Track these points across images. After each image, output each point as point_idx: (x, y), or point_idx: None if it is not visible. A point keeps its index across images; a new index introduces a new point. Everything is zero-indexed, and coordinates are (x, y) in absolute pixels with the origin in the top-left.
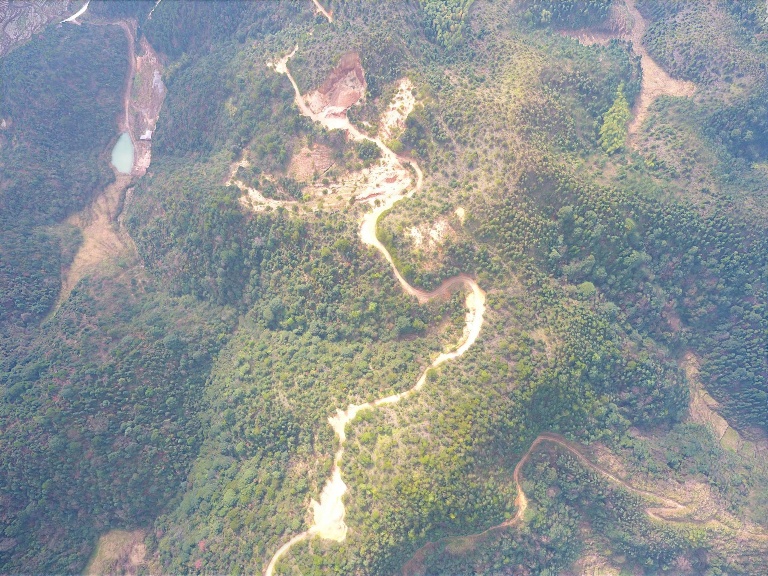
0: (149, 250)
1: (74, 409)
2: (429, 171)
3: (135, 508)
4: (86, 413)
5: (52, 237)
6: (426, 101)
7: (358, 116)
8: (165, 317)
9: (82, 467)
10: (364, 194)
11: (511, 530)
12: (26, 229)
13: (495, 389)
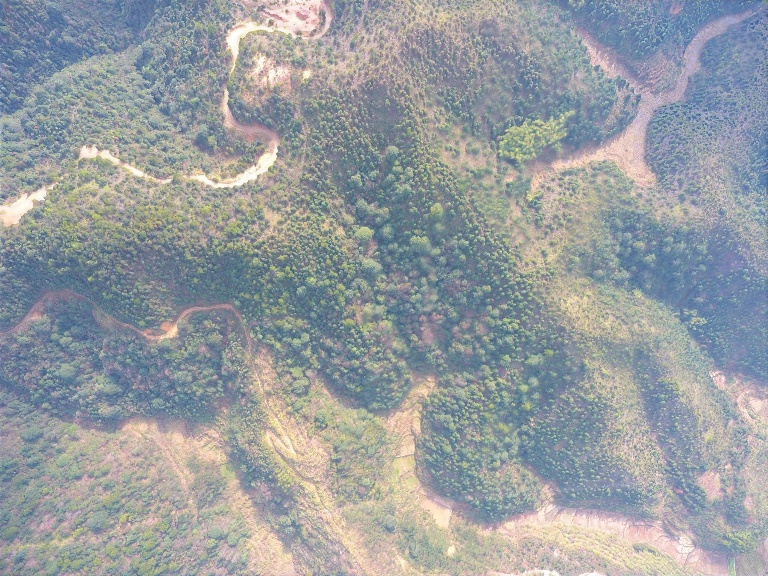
0: None
1: None
2: (331, 32)
3: None
4: None
5: None
6: None
7: None
8: None
9: None
10: (273, 11)
11: (142, 340)
12: None
13: None
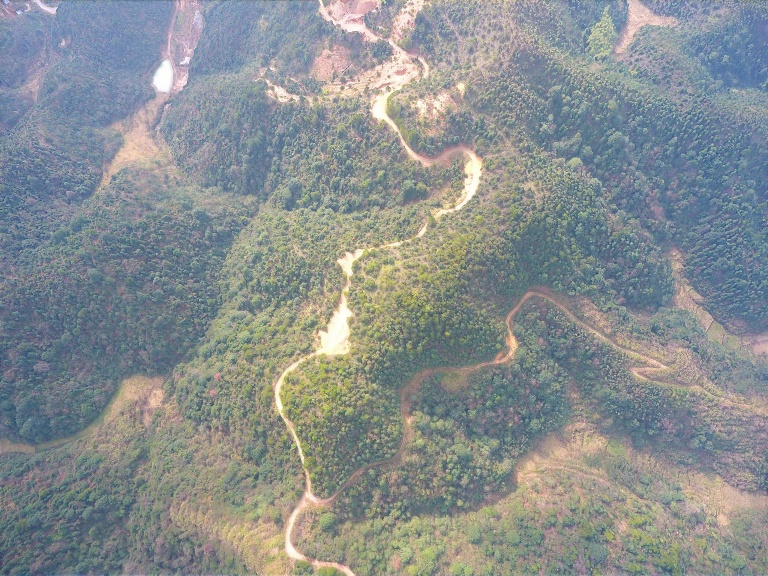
0: (182, 150)
1: (111, 251)
2: (435, 63)
3: (157, 350)
4: (121, 257)
5: (98, 135)
6: (433, 1)
7: (374, 21)
8: (194, 197)
9: (114, 301)
10: (377, 85)
11: (502, 365)
12: (76, 126)
13: (488, 229)
